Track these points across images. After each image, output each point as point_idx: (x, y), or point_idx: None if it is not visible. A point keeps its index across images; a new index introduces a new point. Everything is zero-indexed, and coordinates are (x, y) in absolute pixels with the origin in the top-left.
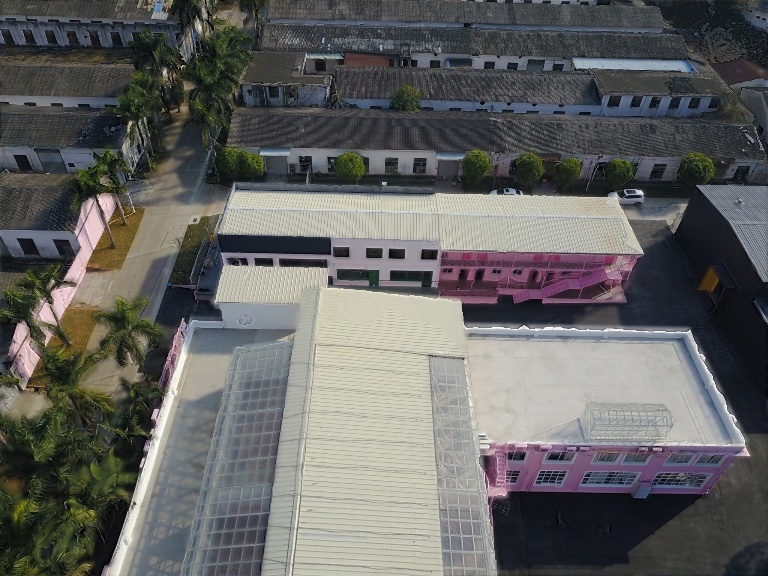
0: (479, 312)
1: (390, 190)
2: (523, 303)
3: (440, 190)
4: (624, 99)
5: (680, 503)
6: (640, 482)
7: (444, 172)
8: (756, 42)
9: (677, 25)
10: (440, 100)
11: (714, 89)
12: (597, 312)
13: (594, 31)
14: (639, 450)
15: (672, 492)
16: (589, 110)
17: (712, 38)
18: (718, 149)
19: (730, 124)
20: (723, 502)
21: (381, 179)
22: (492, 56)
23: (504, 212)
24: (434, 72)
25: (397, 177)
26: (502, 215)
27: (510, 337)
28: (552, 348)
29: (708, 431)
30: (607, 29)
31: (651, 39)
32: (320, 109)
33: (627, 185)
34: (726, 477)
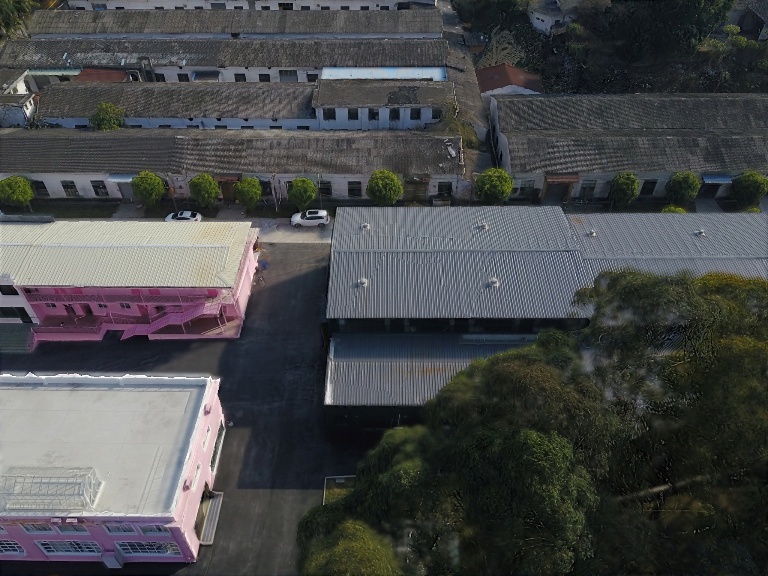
0: (76, 350)
1: (5, 219)
2: (128, 339)
3: (120, 214)
4: (339, 112)
5: (159, 573)
6: (104, 551)
7: (130, 194)
8: (533, 45)
9: (473, 28)
10: (145, 117)
11: (437, 99)
12: (202, 349)
13: (364, 38)
14: (51, 521)
15: (157, 560)
16: (306, 124)
17: (497, 42)
18: (413, 164)
19: (436, 137)
20: (207, 572)
21: (65, 203)
22: (239, 68)
23: (106, 242)
24: (147, 87)
25: (81, 200)
26: (101, 245)
27: (16, 386)
28: (52, 398)
29: (153, 497)
30: (382, 35)
31: (412, 45)
32: (14, 130)
33: (311, 205)
34: (227, 542)
